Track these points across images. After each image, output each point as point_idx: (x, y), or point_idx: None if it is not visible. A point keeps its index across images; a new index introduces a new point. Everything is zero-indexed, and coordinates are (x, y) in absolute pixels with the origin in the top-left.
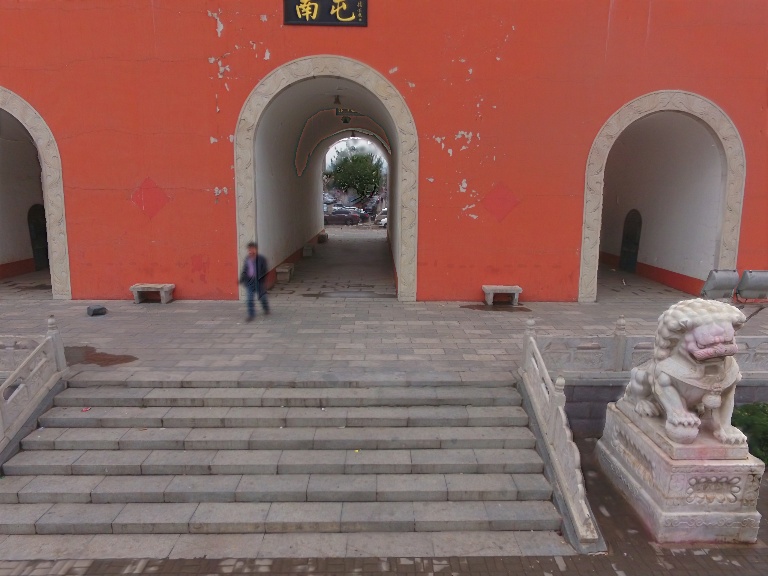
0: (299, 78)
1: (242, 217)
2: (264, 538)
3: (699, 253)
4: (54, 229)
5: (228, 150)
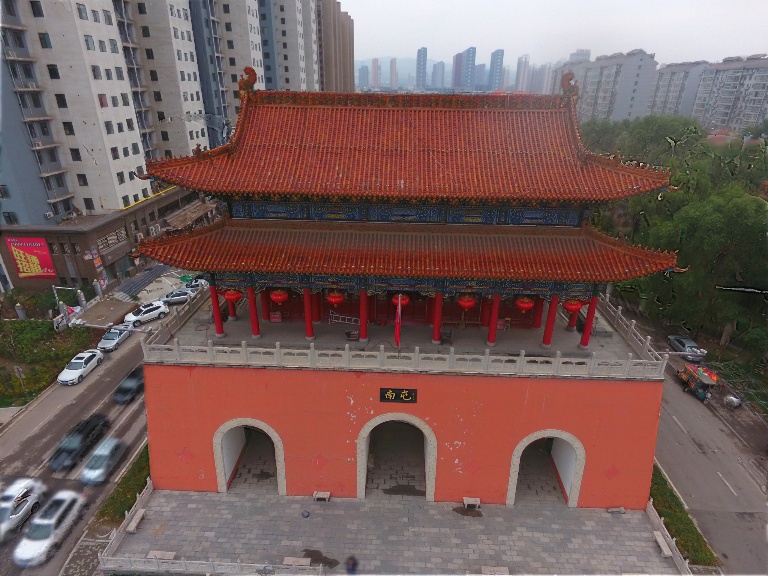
0: None
1: (359, 469)
2: None
3: (567, 480)
4: (280, 471)
5: (354, 445)
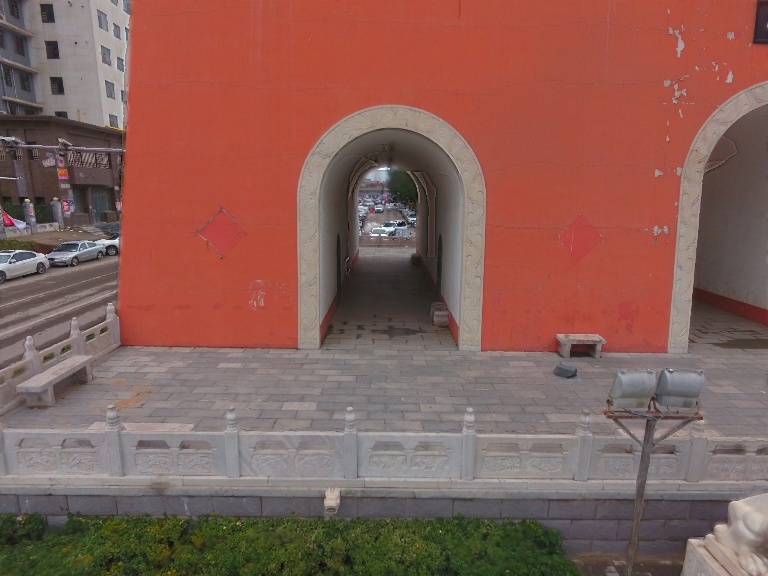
0: (764, 103)
1: (681, 260)
2: None
3: None
4: (470, 272)
5: (673, 184)
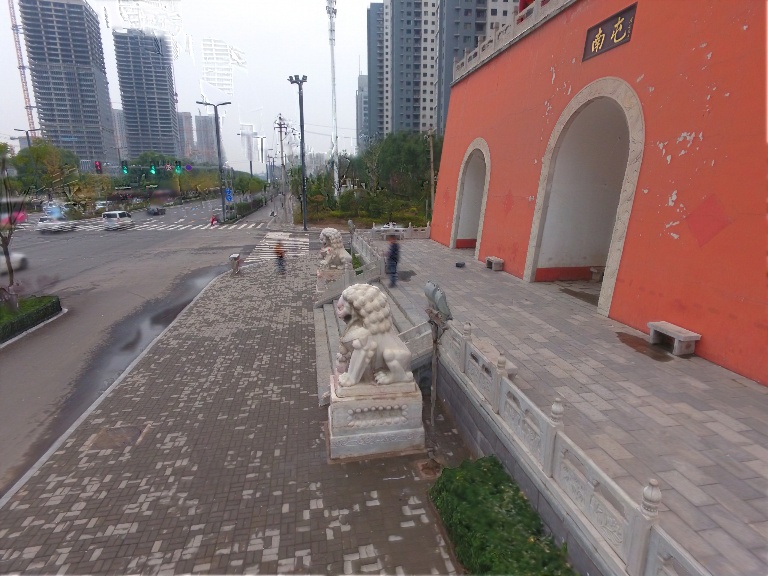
0: (581, 104)
1: (535, 219)
2: (325, 341)
3: None
4: (481, 219)
5: (540, 168)
